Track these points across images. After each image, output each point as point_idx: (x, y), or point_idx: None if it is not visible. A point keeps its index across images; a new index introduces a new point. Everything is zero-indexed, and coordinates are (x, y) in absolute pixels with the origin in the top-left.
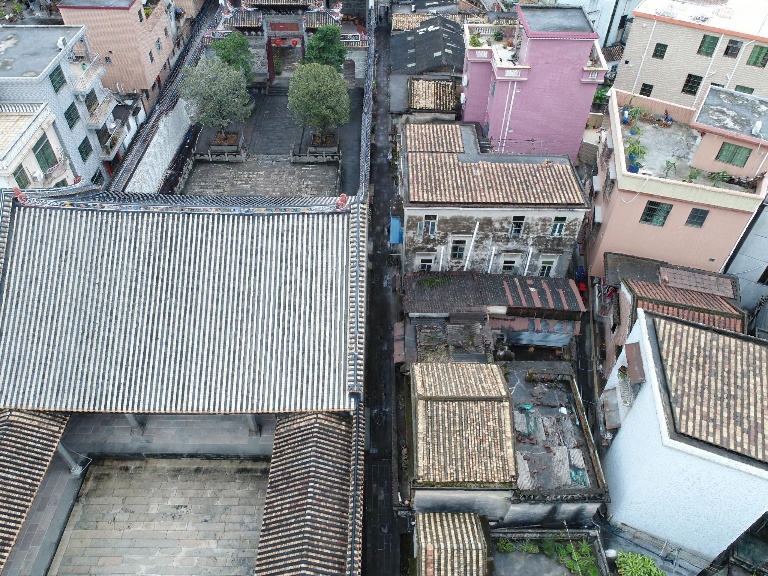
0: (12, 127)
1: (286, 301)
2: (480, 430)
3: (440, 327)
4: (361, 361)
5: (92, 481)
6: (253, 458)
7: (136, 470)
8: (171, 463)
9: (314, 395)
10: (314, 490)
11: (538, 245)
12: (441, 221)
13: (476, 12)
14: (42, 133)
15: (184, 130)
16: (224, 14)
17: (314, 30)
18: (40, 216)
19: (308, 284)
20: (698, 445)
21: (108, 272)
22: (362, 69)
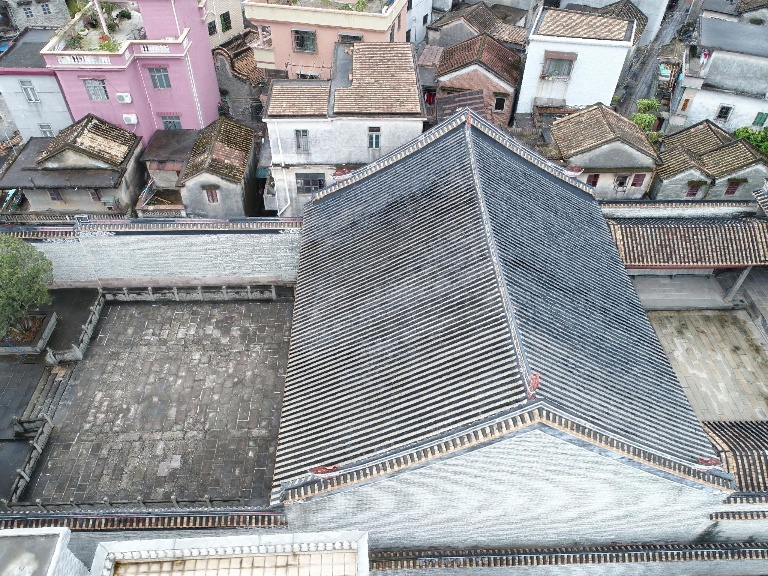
0: None
1: None
2: None
3: None
4: None
5: None
6: None
7: None
8: None
9: None
10: None
11: None
12: None
13: None
14: None
15: None
16: None
17: None
18: None
19: None
20: (627, 38)
21: None
22: None
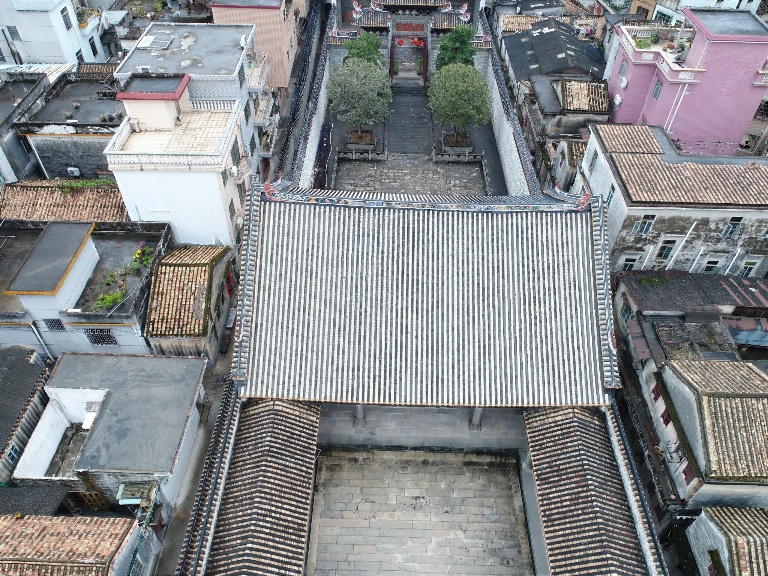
0: (208, 123)
1: (531, 297)
2: (765, 426)
3: (677, 325)
4: (615, 357)
5: (325, 471)
6: (476, 451)
7: (365, 461)
8: (397, 455)
9: (567, 390)
10: (593, 483)
11: (747, 246)
12: (658, 221)
13: (584, 14)
14: (237, 130)
15: (320, 128)
16: (354, 14)
17: (439, 31)
18: (285, 211)
19: (551, 281)
20: None
21: (354, 266)
22: (481, 70)
